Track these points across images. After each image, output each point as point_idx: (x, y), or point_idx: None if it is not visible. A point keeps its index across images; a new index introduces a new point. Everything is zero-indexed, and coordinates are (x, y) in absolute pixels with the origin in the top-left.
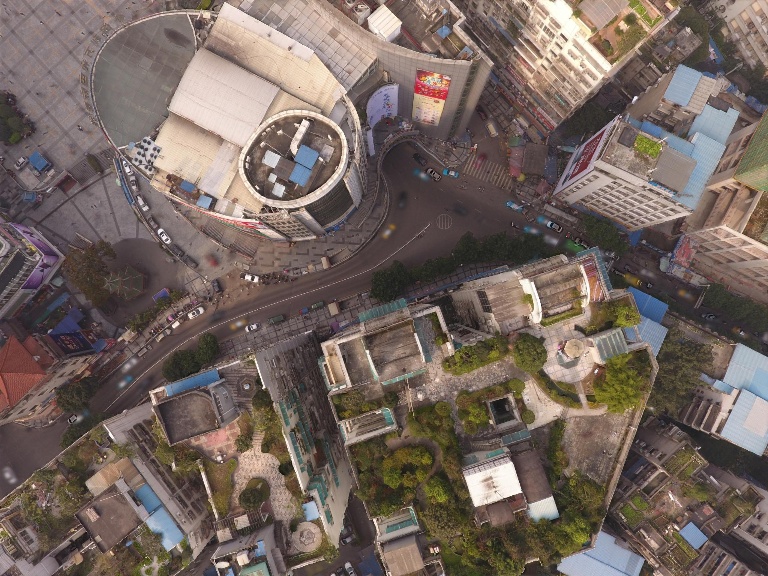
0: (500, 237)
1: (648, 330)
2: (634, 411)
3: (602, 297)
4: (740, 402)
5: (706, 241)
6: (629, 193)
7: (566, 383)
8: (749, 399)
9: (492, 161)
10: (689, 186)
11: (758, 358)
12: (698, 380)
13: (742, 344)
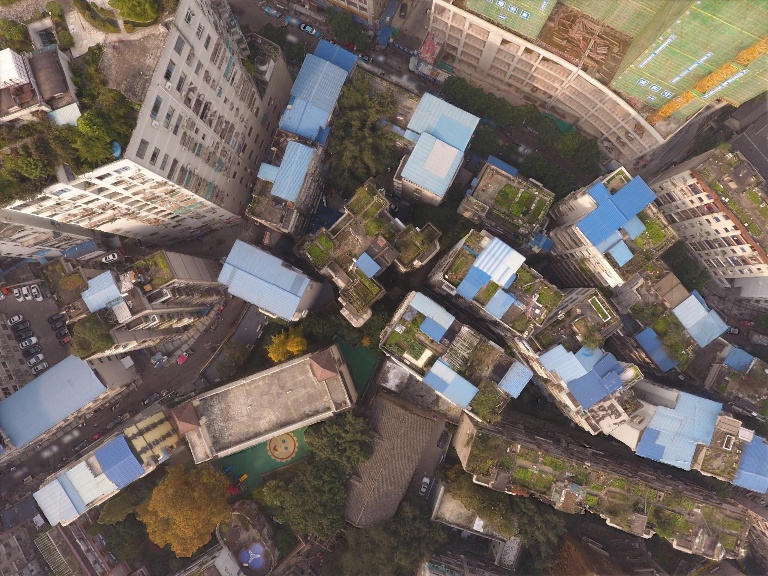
0: None
1: (328, 72)
2: None
3: None
4: (420, 144)
5: (445, 34)
6: None
7: (105, 10)
8: (429, 141)
9: None
10: None
11: (443, 106)
12: (393, 134)
13: None
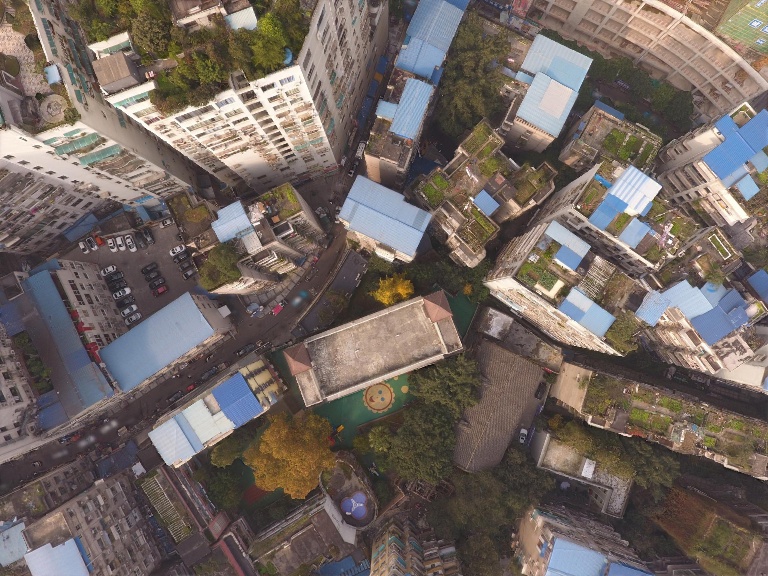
0: None
1: (444, 12)
2: None
3: None
4: (535, 83)
5: None
6: None
7: None
8: (544, 81)
9: None
10: None
11: (556, 47)
12: (503, 76)
13: None
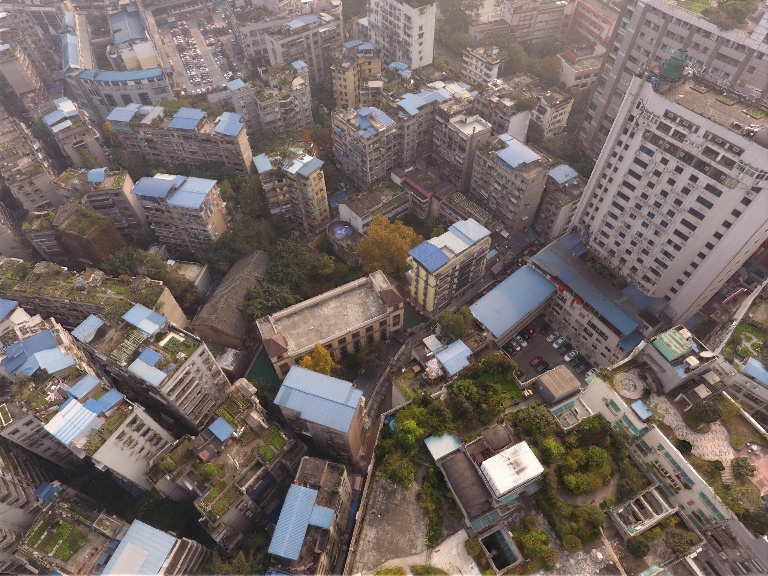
0: None
1: None
2: (350, 571)
3: None
4: None
5: None
6: None
7: None
8: None
9: None
10: None
11: None
12: None
13: None
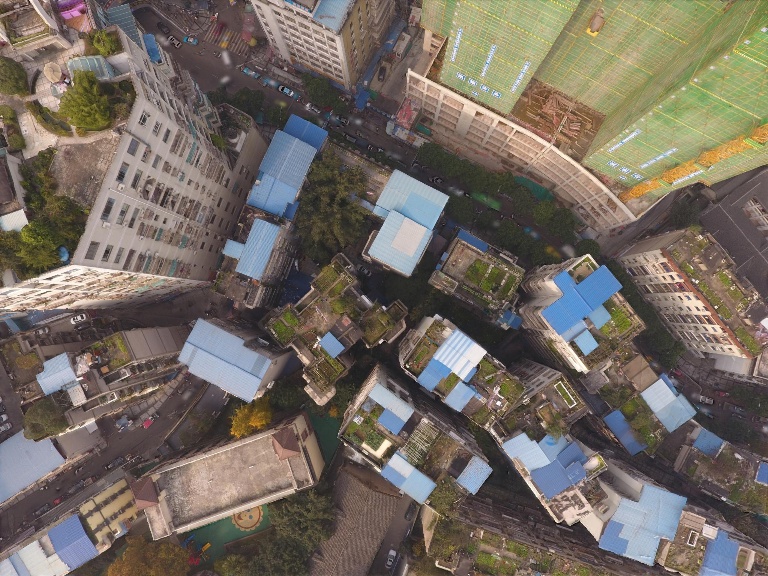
0: (217, 92)
1: (297, 149)
2: None
3: (90, 29)
4: (388, 222)
5: None
6: (294, 25)
7: None
8: (397, 219)
9: (232, 29)
10: (331, 8)
11: (413, 183)
12: (363, 208)
13: (398, 170)
